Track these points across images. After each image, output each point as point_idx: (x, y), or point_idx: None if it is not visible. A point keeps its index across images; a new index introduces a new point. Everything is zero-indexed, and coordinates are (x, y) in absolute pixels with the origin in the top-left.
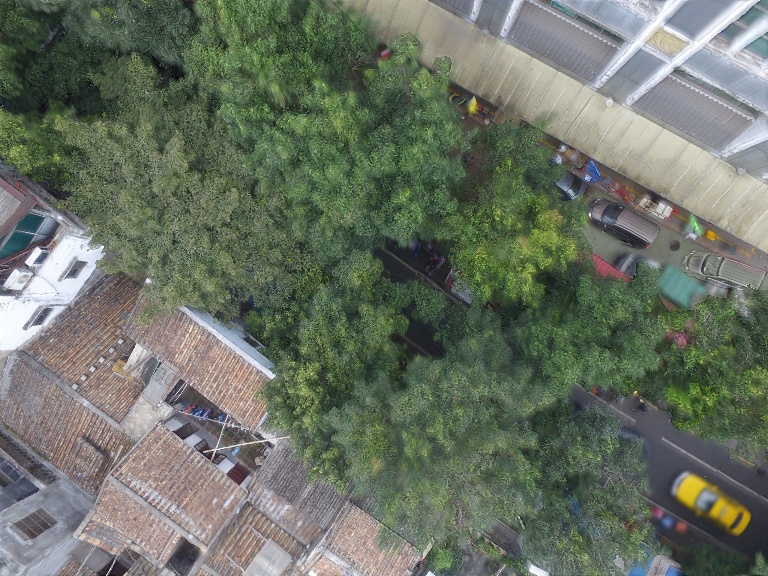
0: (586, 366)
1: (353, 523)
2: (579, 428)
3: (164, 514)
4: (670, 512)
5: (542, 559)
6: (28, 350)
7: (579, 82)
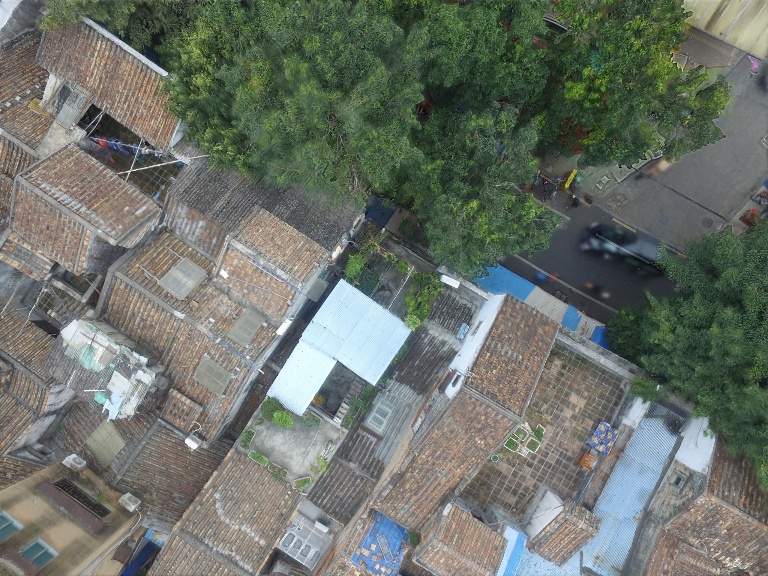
0: (476, 40)
1: (261, 222)
2: (477, 117)
3: (73, 212)
4: (605, 305)
5: (444, 242)
6: None
7: None
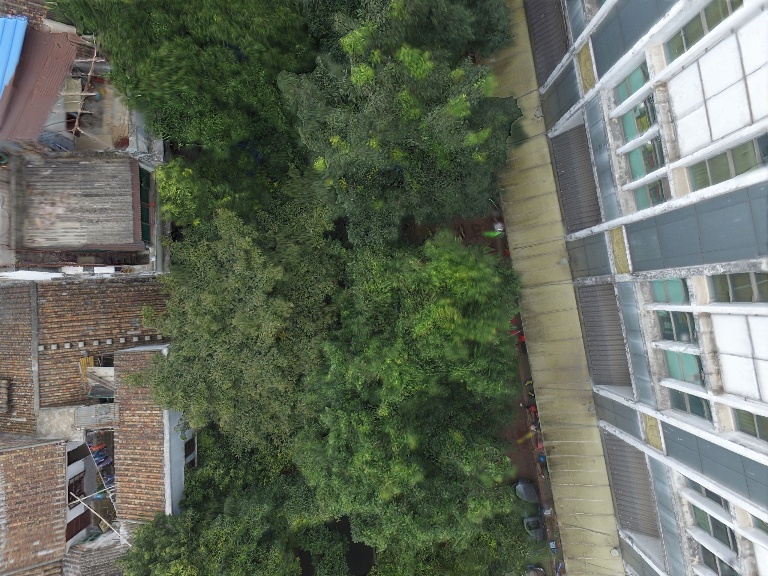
0: None
1: None
2: None
3: None
4: None
5: None
6: (41, 286)
7: (614, 509)
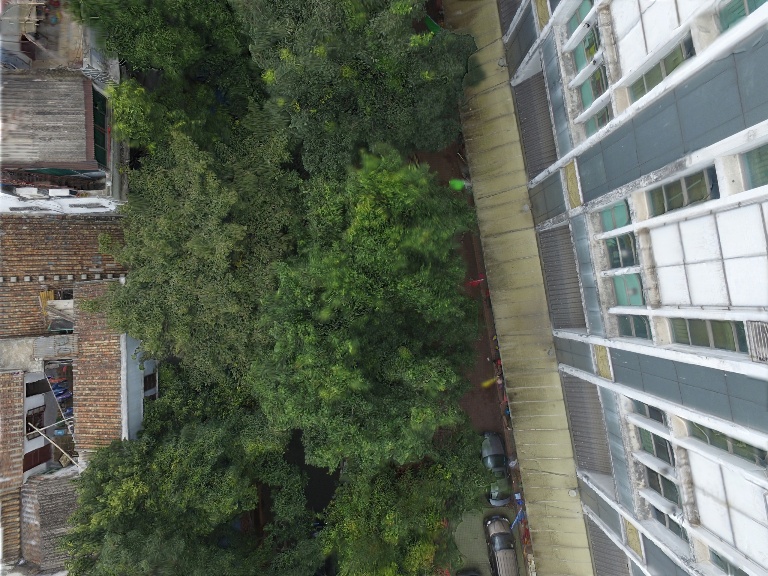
0: None
1: None
2: None
3: None
4: None
5: None
6: (0, 219)
7: (573, 452)
